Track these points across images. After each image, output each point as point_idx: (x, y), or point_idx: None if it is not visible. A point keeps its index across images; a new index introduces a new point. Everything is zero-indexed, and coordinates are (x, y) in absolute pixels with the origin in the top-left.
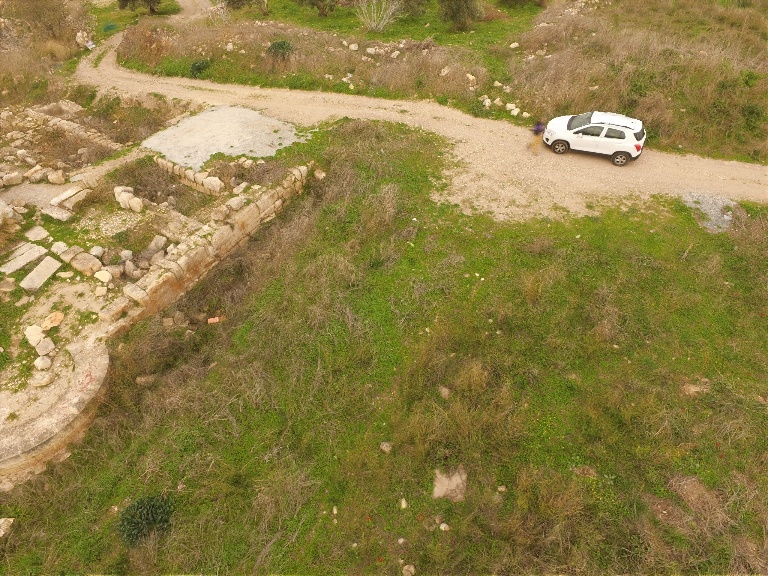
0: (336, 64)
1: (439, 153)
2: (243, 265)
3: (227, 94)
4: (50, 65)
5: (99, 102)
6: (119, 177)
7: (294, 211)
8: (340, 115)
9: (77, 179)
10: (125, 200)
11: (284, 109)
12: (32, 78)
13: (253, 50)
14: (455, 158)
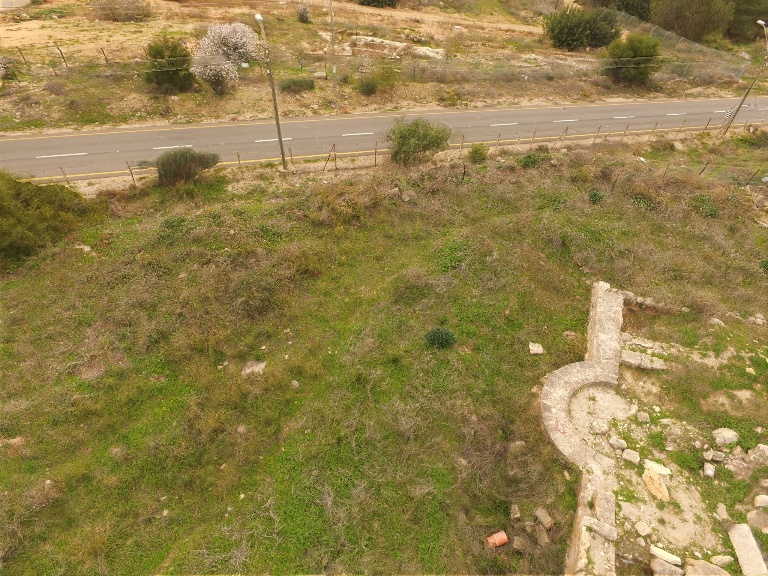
0: None
1: None
2: None
3: None
4: None
5: None
6: None
7: None
8: None
9: None
10: None
11: None
12: None
13: None
14: None
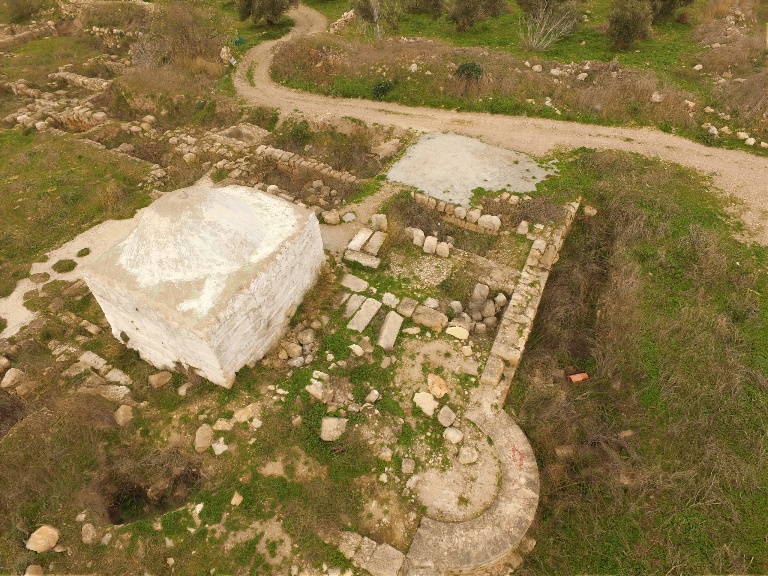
0: (530, 87)
1: (704, 187)
2: (572, 314)
3: (427, 119)
4: (209, 84)
5: (284, 126)
6: (392, 216)
7: (586, 252)
8: (567, 144)
9: (351, 219)
10: (433, 245)
11: (501, 136)
12: (194, 98)
13: (440, 72)
14: (724, 193)
